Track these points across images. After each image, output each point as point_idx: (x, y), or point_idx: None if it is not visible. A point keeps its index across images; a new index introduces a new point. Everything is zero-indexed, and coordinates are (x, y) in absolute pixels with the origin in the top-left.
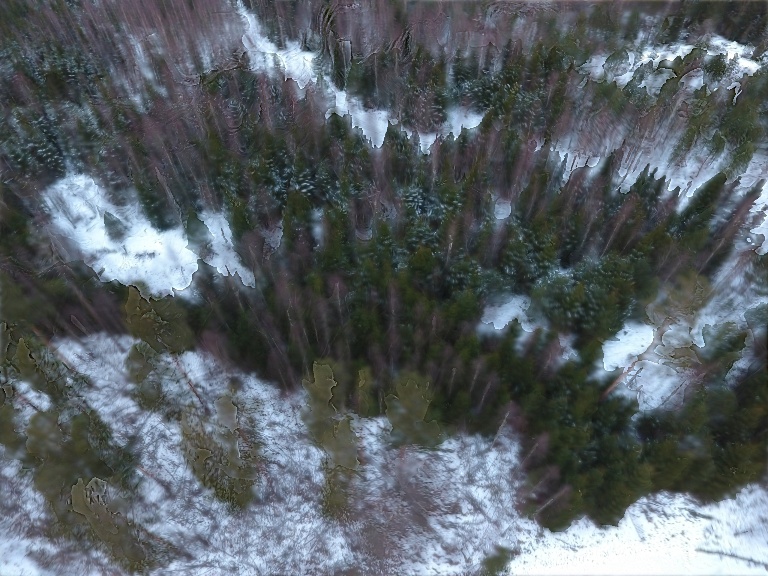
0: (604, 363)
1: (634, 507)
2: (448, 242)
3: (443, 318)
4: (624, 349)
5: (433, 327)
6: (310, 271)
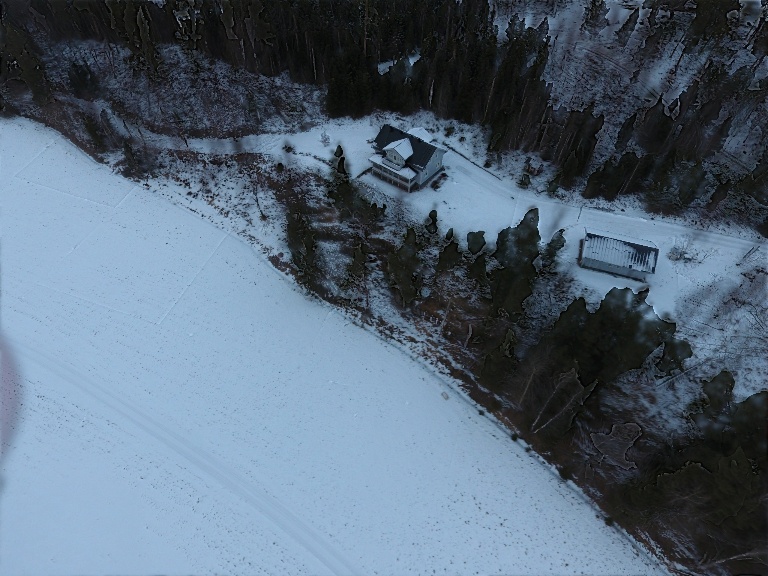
0: (385, 67)
1: (373, 115)
2: (321, 3)
3: (302, 22)
4: None
5: (295, 23)
6: None
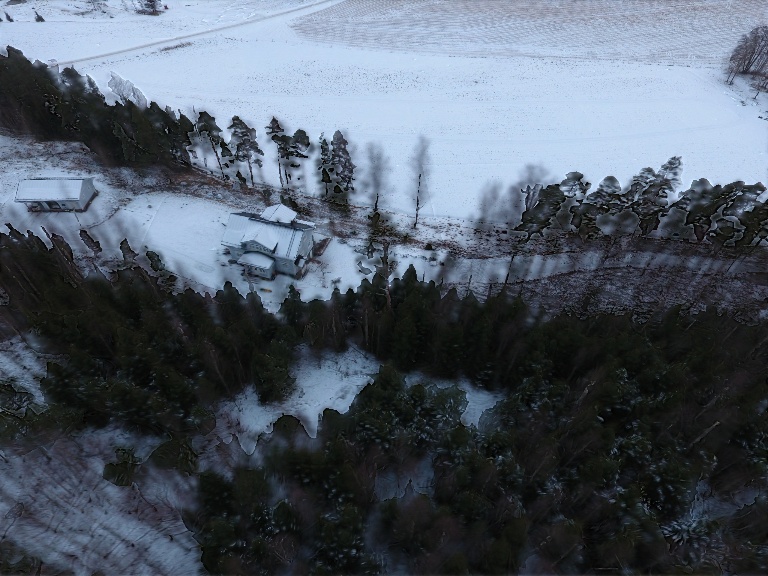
0: None
1: None
2: None
3: None
4: (349, 403)
5: None
6: (711, 366)
